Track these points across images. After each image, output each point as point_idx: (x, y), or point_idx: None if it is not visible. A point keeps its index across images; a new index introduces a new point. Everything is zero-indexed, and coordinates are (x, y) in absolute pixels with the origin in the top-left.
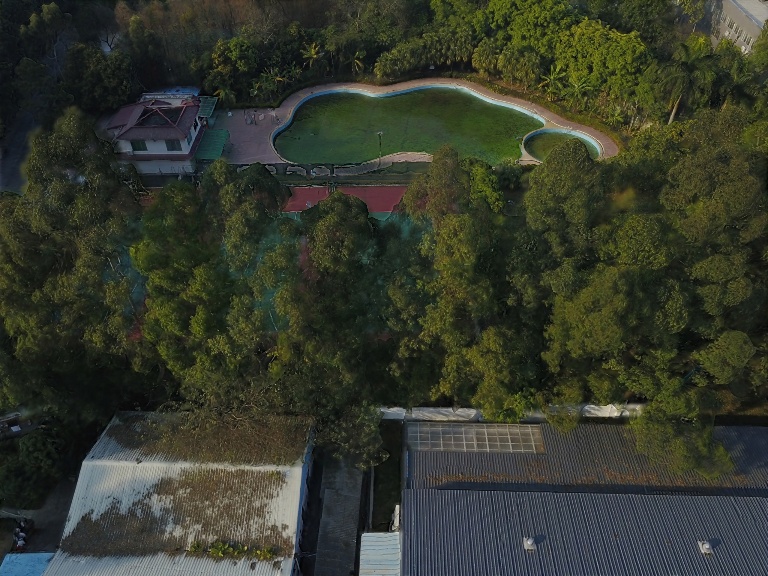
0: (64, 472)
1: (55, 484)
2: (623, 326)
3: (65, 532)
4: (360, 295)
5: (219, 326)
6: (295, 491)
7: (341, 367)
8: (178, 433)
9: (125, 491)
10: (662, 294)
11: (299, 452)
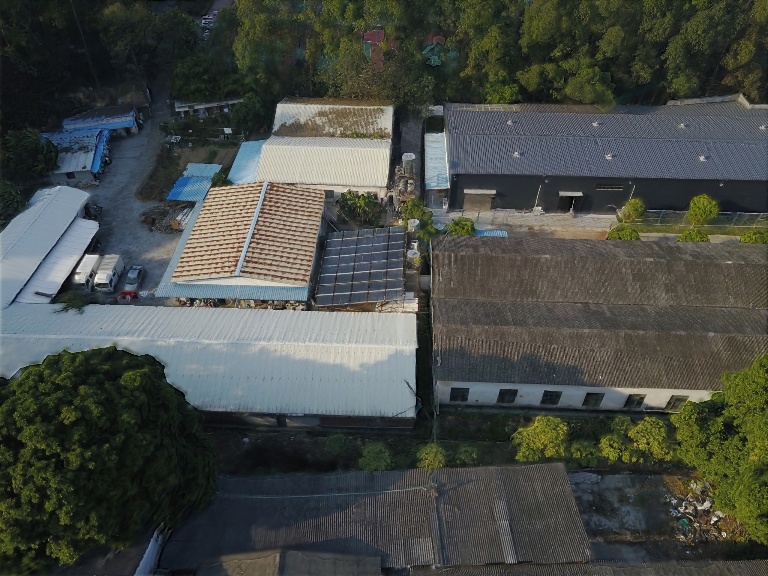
0: (263, 117)
1: (258, 123)
2: (557, 12)
3: (273, 130)
4: (427, 8)
5: (358, 16)
6: (390, 116)
7: (415, 52)
8: (323, 101)
9: (301, 115)
10: (577, 0)
11: (390, 104)
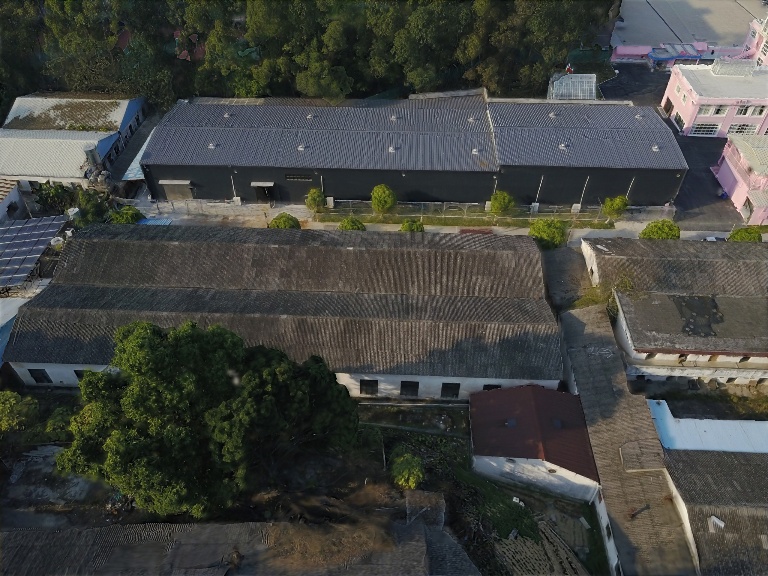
0: (8, 110)
1: (3, 116)
2: (269, 7)
3: (5, 123)
4: (153, 3)
5: (80, 11)
6: (123, 109)
7: (148, 46)
8: None
9: (37, 109)
10: None
11: (130, 98)
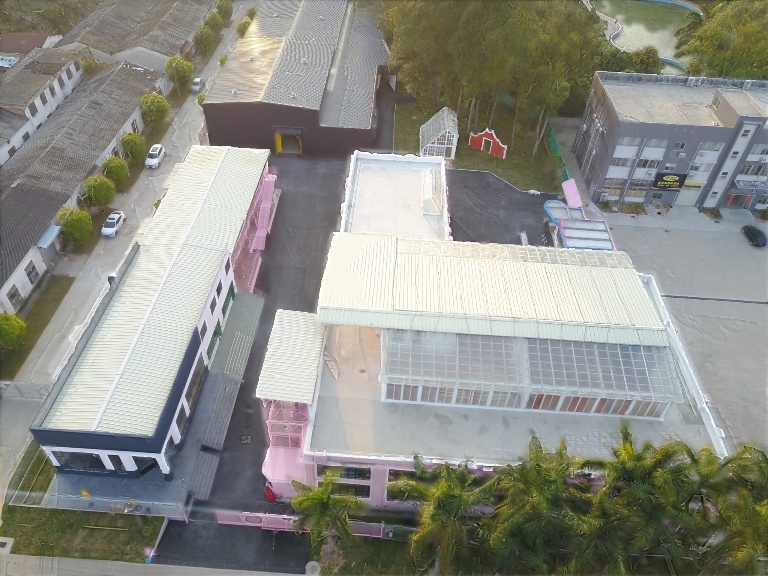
0: None
1: None
2: None
3: None
4: None
5: None
6: None
7: None
8: None
9: None
10: None
11: None
